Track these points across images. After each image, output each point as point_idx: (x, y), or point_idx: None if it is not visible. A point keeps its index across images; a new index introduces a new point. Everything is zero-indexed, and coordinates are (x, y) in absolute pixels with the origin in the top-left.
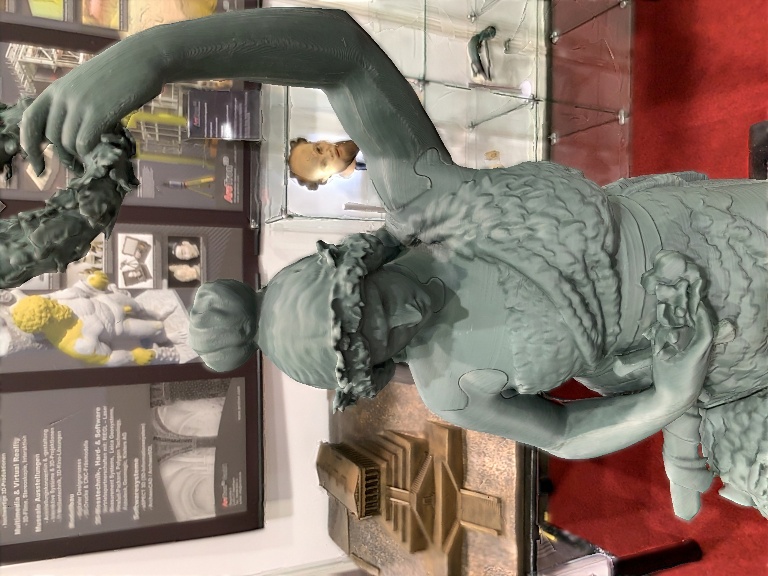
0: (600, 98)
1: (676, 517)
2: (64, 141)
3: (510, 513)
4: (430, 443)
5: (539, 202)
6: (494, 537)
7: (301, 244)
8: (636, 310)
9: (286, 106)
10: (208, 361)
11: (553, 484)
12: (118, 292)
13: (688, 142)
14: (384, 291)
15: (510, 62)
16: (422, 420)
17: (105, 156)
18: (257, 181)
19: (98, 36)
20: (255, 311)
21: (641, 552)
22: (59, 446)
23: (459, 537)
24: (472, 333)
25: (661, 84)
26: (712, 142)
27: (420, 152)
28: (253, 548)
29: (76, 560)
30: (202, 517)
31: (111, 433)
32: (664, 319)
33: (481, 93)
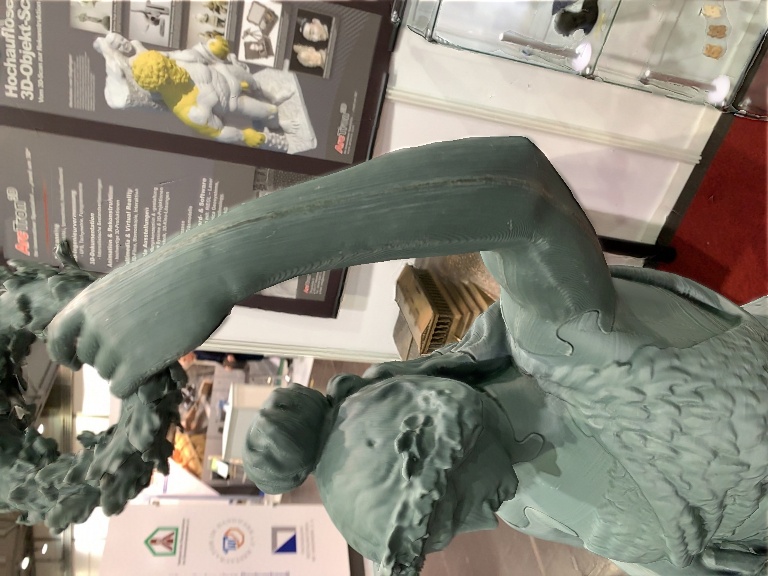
0: None
1: None
2: None
3: None
4: None
5: (702, 426)
6: None
7: (443, 47)
8: (764, 523)
9: None
10: None
11: None
12: (237, 64)
13: None
14: (462, 492)
15: None
16: None
17: (138, 430)
18: None
19: None
20: (316, 453)
21: None
22: (166, 205)
23: None
24: (556, 491)
25: None
26: None
27: (573, 317)
28: (324, 328)
29: None
30: (284, 296)
31: (214, 205)
32: None
33: None
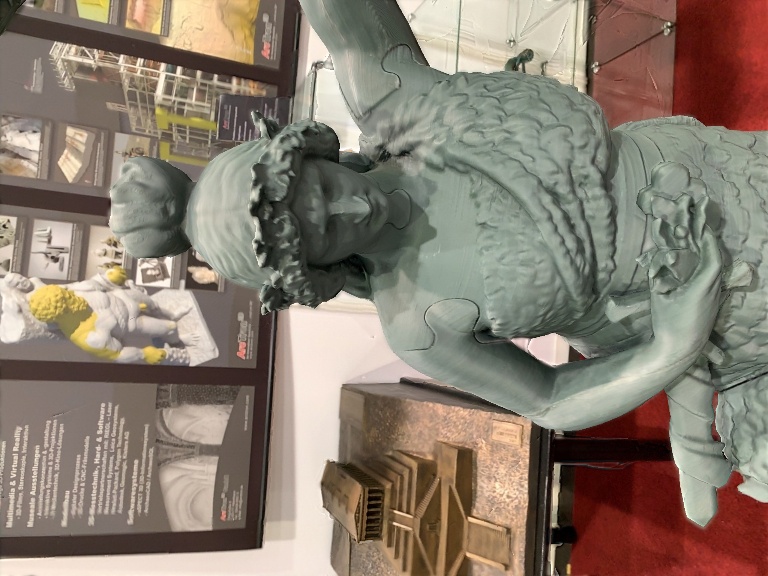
0: None
1: None
2: None
3: (520, 546)
4: (439, 465)
5: (519, 103)
6: (501, 572)
7: None
8: (634, 245)
9: (311, 107)
10: (126, 244)
11: (578, 533)
12: (135, 288)
13: None
14: (328, 176)
15: None
16: (432, 440)
17: None
18: None
19: (139, 39)
20: (184, 194)
21: None
22: (60, 439)
23: (464, 570)
24: (440, 255)
25: (705, 110)
26: None
27: (389, 46)
28: (250, 570)
29: (65, 562)
30: (198, 529)
31: (113, 431)
32: (660, 238)
33: None
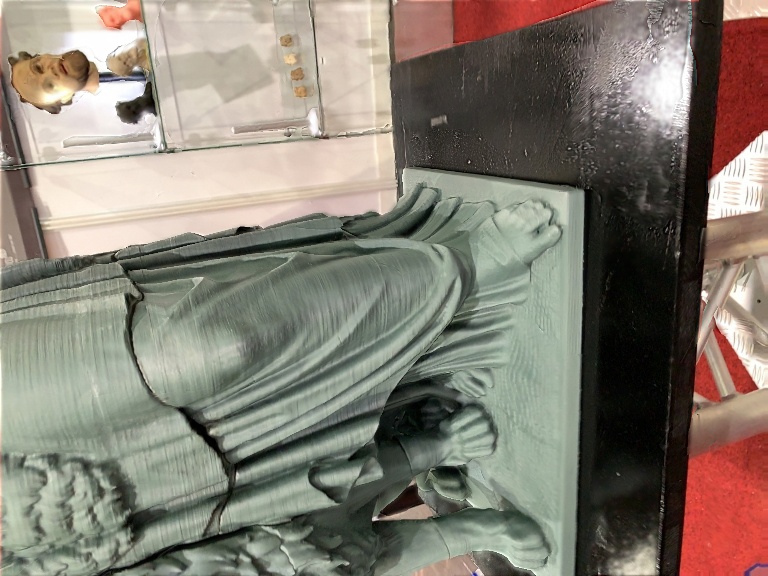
0: None
1: None
2: None
3: None
4: None
5: None
6: None
7: (84, 167)
8: None
9: None
10: None
11: None
12: None
13: (500, 13)
14: None
15: None
16: None
17: None
18: (5, 101)
19: None
20: None
21: None
22: None
23: None
24: None
25: None
26: (519, 16)
27: None
28: None
29: None
30: None
31: None
32: None
33: None
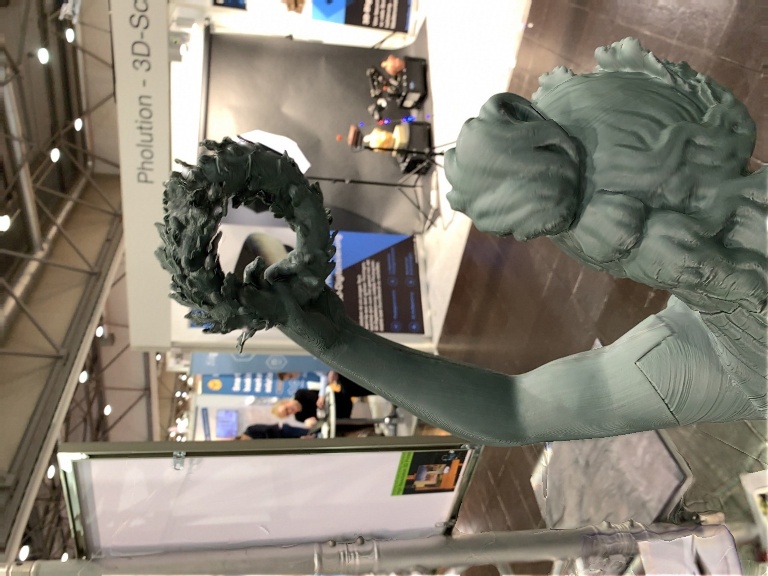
0: None
1: None
2: None
3: None
4: None
5: None
6: None
7: None
8: None
9: None
10: None
11: None
12: None
13: None
14: None
15: None
16: None
17: None
18: None
19: None
20: None
21: None
22: None
23: None
24: None
25: None
26: None
27: None
28: None
29: None
30: None
31: None
32: None
33: None
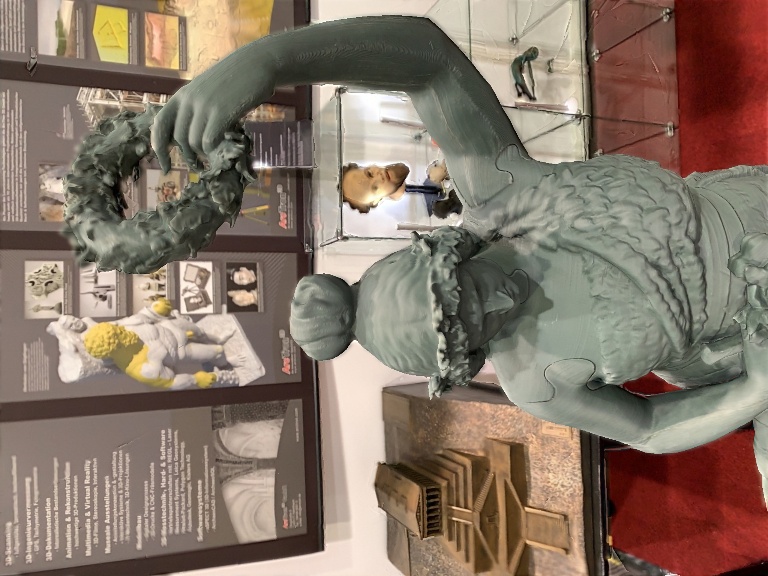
0: (646, 112)
1: (753, 538)
2: (191, 141)
3: (578, 531)
4: (491, 461)
5: (621, 191)
6: (562, 556)
7: (353, 267)
8: (722, 297)
9: (339, 131)
10: (310, 350)
11: (617, 507)
12: (180, 318)
13: (743, 149)
14: (476, 279)
15: (553, 81)
16: (482, 437)
17: (231, 151)
18: (310, 207)
19: (160, 76)
20: (352, 302)
21: (718, 575)
22: (127, 468)
23: (525, 557)
24: (557, 323)
25: (711, 93)
26: None
27: (501, 148)
28: (313, 572)
29: None
30: (263, 539)
31: (175, 455)
32: (756, 301)
33: (525, 113)
